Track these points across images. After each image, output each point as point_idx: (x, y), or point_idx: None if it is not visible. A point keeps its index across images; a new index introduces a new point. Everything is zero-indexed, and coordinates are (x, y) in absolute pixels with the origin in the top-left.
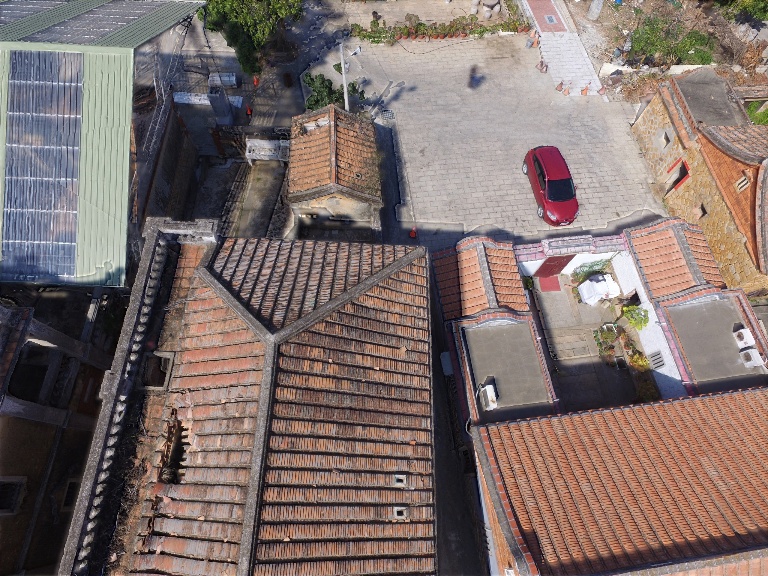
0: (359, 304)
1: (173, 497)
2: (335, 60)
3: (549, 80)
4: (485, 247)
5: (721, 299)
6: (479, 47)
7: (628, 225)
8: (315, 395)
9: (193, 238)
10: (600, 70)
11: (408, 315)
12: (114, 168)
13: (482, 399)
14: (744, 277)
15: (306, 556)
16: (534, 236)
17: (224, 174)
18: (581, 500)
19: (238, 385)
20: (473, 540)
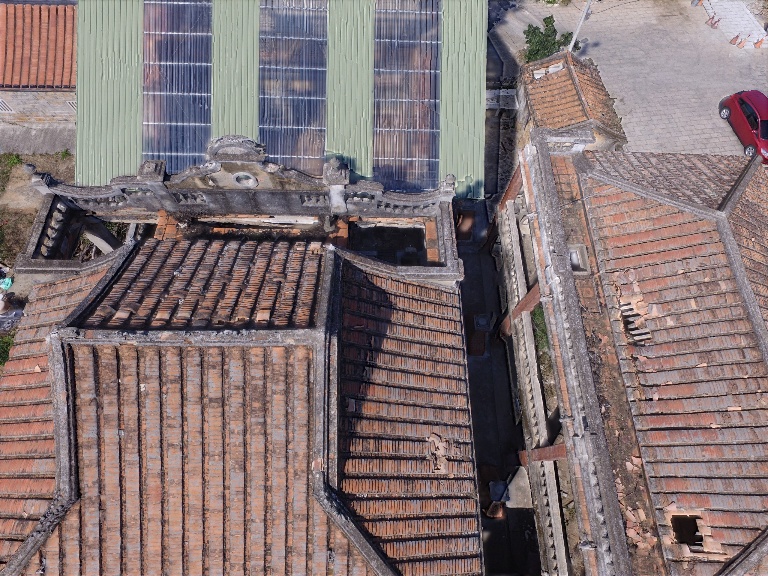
0: None
1: (648, 356)
2: (516, 20)
3: (721, 35)
4: None
5: None
6: (648, 6)
7: None
8: (759, 265)
9: (562, 148)
10: None
11: None
12: (473, 89)
13: None
14: None
15: None
16: None
17: None
18: None
19: (694, 257)
20: None
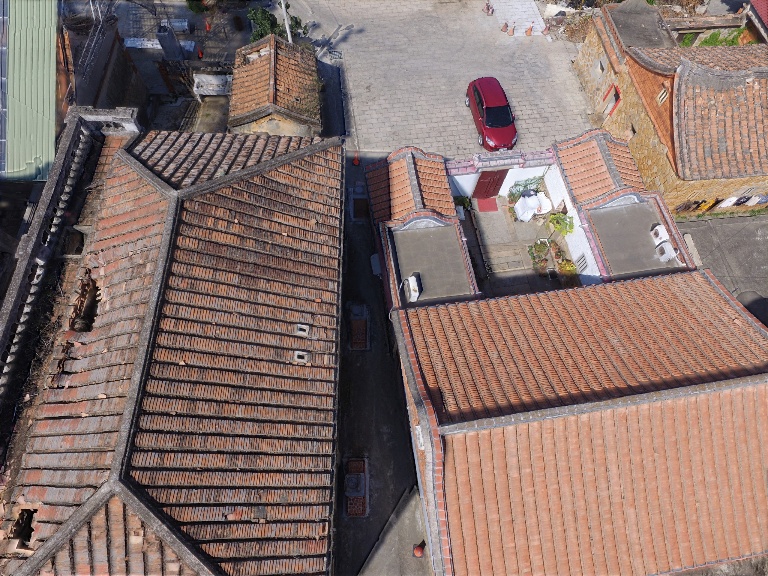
0: (270, 179)
1: (83, 342)
2: None
3: (495, 22)
4: (415, 157)
5: (641, 202)
6: None
7: None
8: (218, 247)
9: (116, 128)
10: (544, 12)
11: (321, 194)
12: (41, 67)
13: (407, 292)
14: (667, 186)
15: (201, 380)
16: None
17: (174, 111)
18: (487, 364)
19: (144, 238)
20: (404, 431)
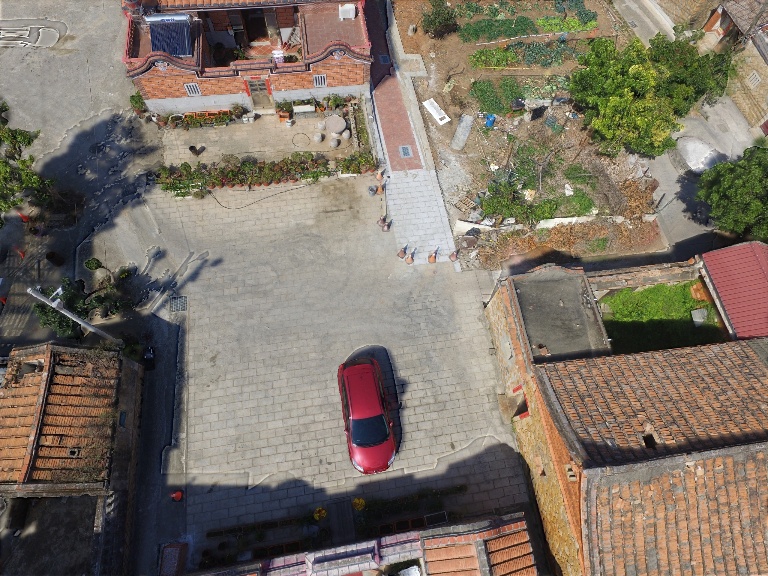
0: None
1: None
2: (128, 221)
3: (391, 242)
4: None
5: None
6: (311, 196)
7: (463, 462)
8: None
9: None
10: None
11: None
12: None
13: None
14: None
15: None
16: (339, 488)
17: None
18: None
19: None
20: None
